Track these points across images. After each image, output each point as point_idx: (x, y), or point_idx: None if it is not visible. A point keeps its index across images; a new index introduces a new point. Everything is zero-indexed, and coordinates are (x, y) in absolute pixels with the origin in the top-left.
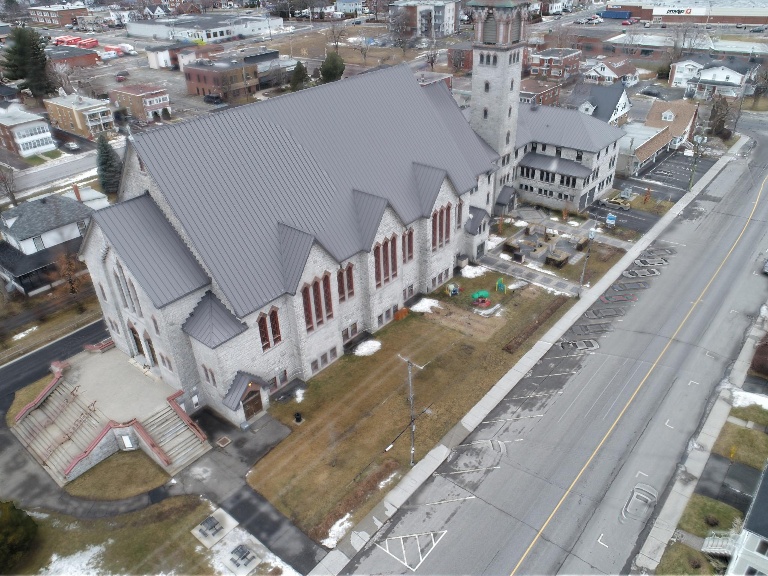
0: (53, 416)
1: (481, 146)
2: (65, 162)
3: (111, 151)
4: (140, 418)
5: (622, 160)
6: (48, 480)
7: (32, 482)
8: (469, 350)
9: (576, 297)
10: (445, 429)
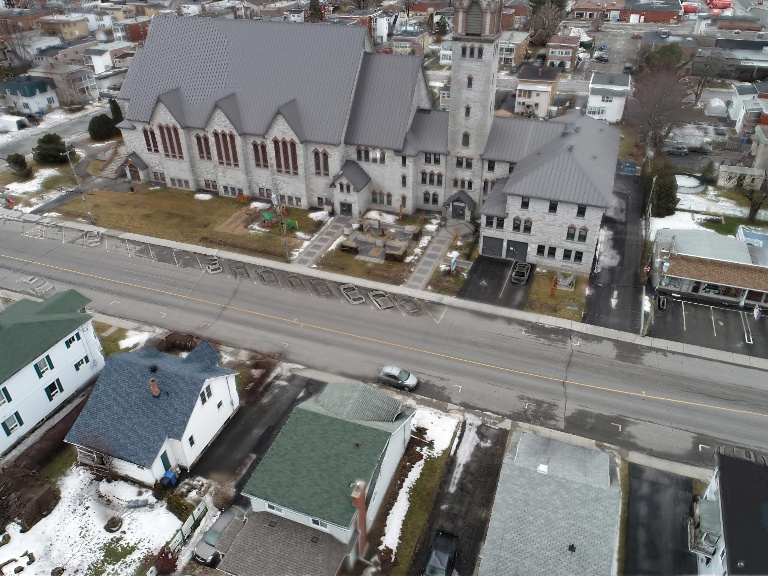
0: None
1: (406, 126)
2: (444, 74)
3: None
4: (121, 152)
5: None
6: None
7: None
8: (202, 226)
9: None
10: (120, 229)
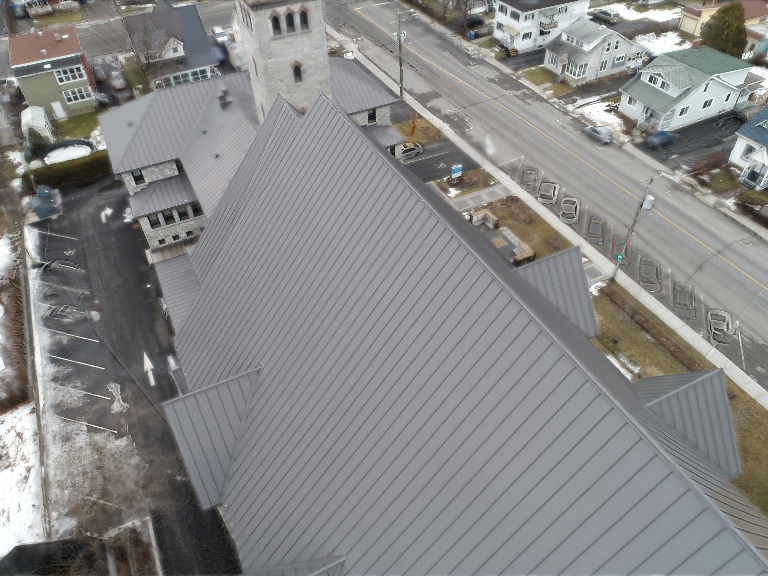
0: None
1: None
2: None
3: None
4: None
5: None
6: None
7: None
8: None
9: (611, 280)
10: None
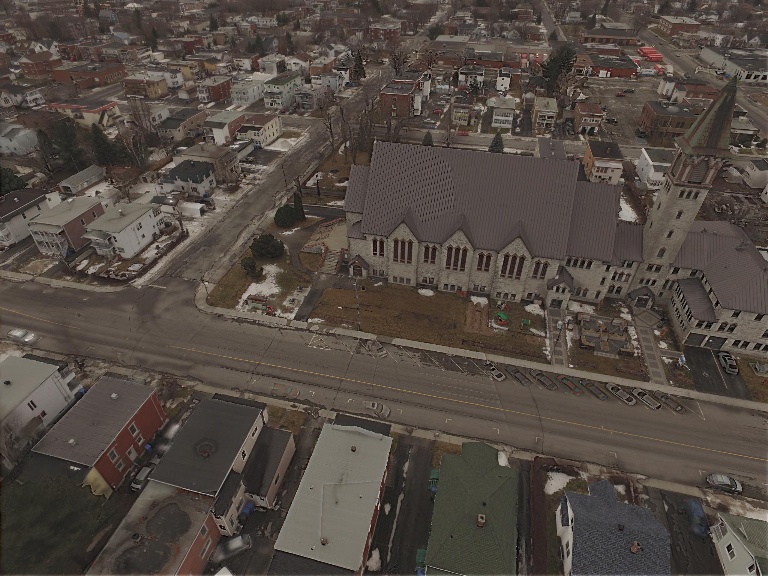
0: (324, 231)
1: (613, 243)
2: None
3: (499, 142)
4: (330, 248)
5: None
6: (302, 247)
7: (299, 245)
8: (452, 327)
9: None
10: (387, 334)
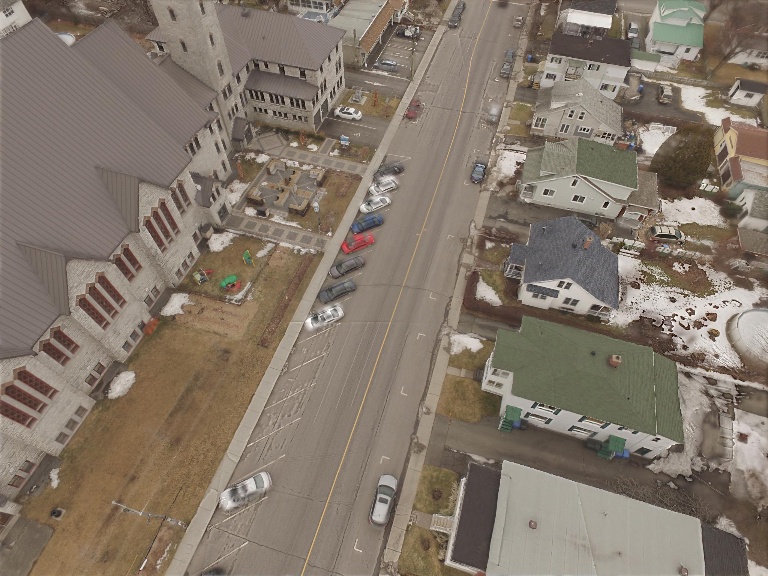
0: None
1: (187, 96)
2: None
3: None
4: None
5: (350, 52)
6: None
7: None
8: (226, 356)
9: (320, 253)
10: (212, 469)
